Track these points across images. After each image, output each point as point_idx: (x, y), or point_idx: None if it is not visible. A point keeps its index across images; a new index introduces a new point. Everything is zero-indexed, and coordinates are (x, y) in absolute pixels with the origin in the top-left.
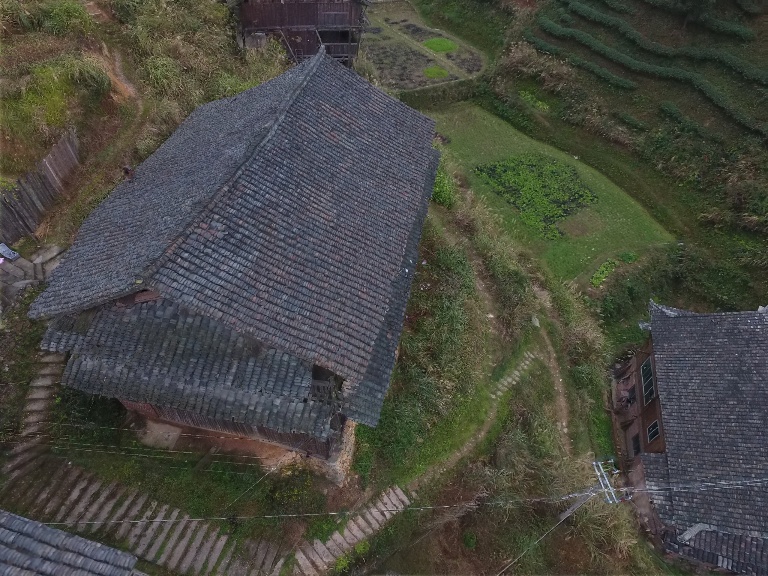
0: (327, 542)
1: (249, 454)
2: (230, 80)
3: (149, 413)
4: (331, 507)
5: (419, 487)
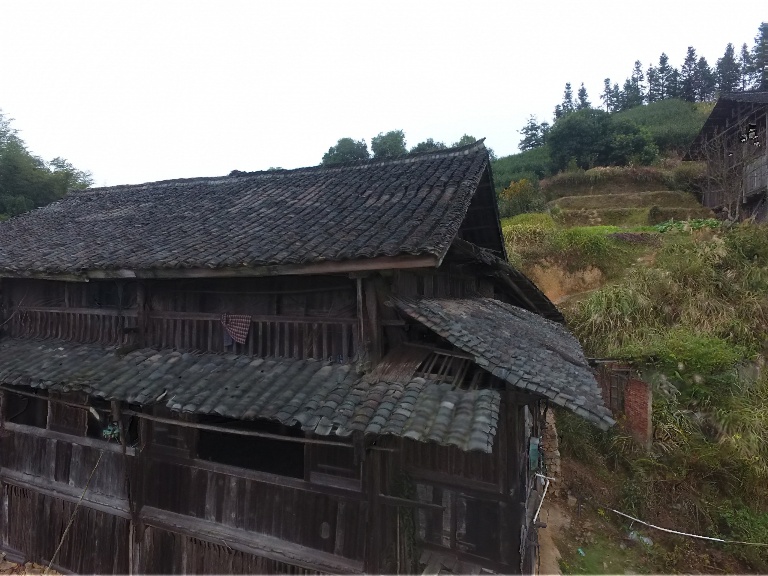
0: None
1: None
2: (682, 331)
3: None
4: None
5: None
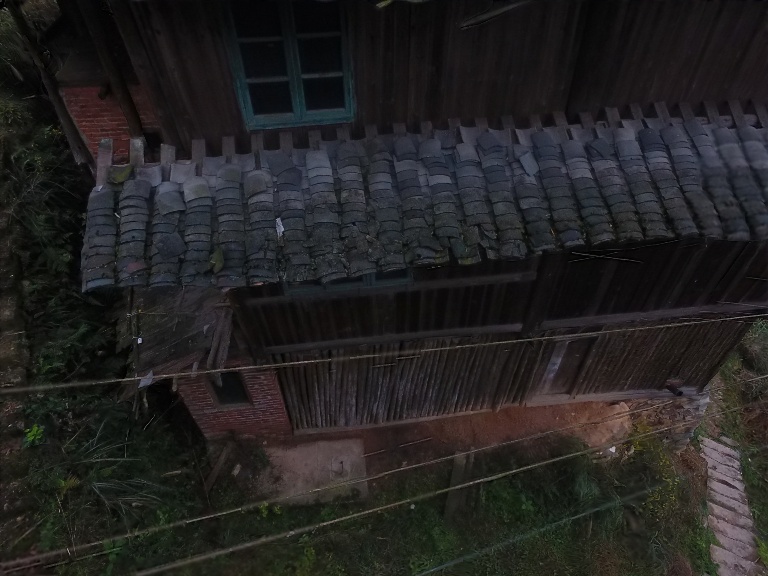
0: (719, 572)
1: (546, 437)
2: None
3: (270, 427)
4: (692, 499)
5: (720, 428)
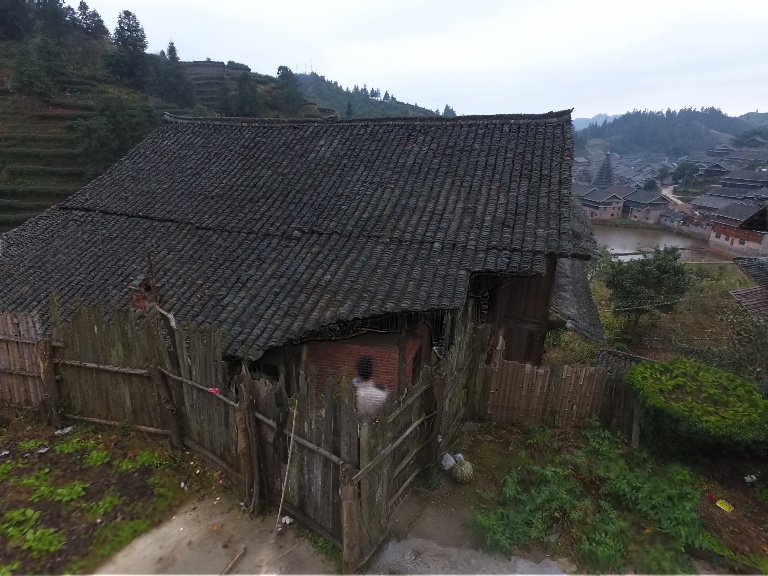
0: None
1: None
2: None
3: None
4: None
5: None
